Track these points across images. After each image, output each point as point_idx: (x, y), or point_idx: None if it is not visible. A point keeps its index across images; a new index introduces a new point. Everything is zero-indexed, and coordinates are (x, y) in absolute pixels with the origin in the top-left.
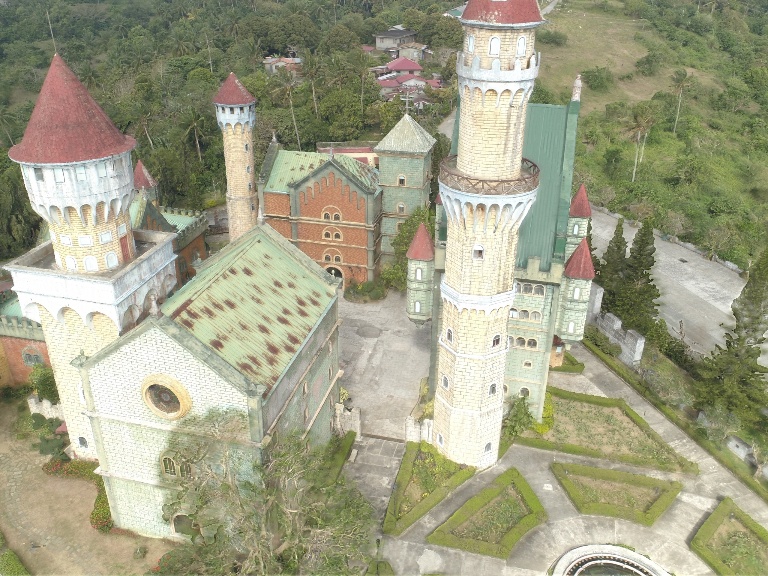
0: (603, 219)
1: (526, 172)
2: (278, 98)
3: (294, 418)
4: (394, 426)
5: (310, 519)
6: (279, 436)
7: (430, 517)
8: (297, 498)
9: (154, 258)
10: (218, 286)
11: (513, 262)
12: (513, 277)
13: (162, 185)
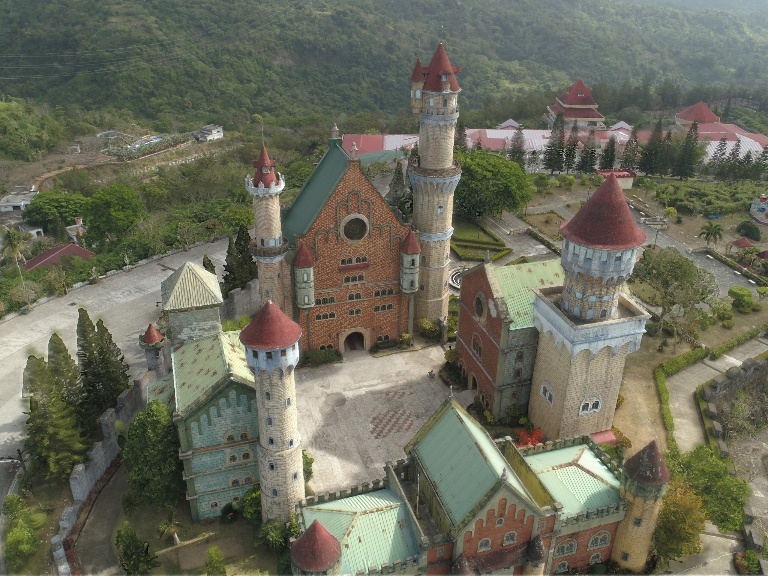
0: None
1: (415, 164)
2: None
3: None
4: (433, 353)
5: None
6: None
7: None
8: None
9: None
10: None
11: None
12: None
13: None
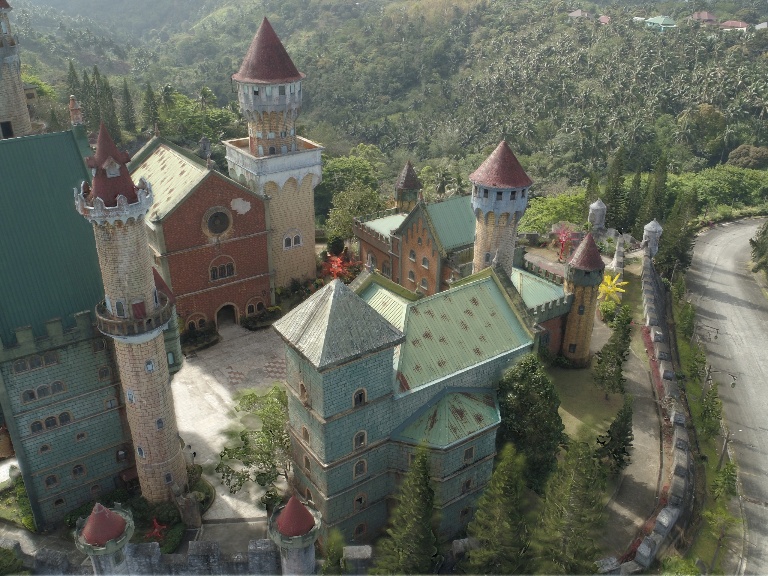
0: None
1: None
2: None
3: None
4: None
5: None
6: None
7: None
8: None
9: None
10: None
11: None
12: None
13: None
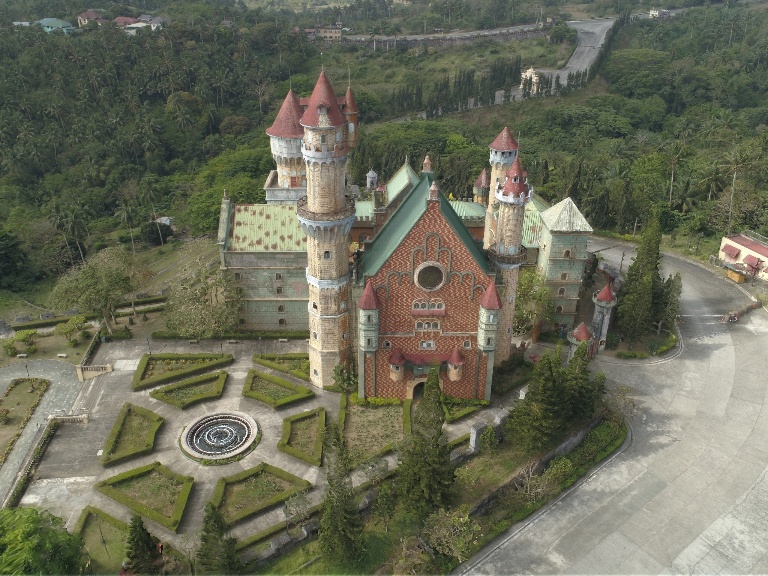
0: None
1: None
2: (723, 173)
3: (264, 282)
4: None
5: (256, 334)
6: (244, 279)
7: (271, 371)
8: (222, 300)
9: (302, 193)
10: (274, 208)
11: (319, 262)
12: (325, 274)
13: (595, 206)
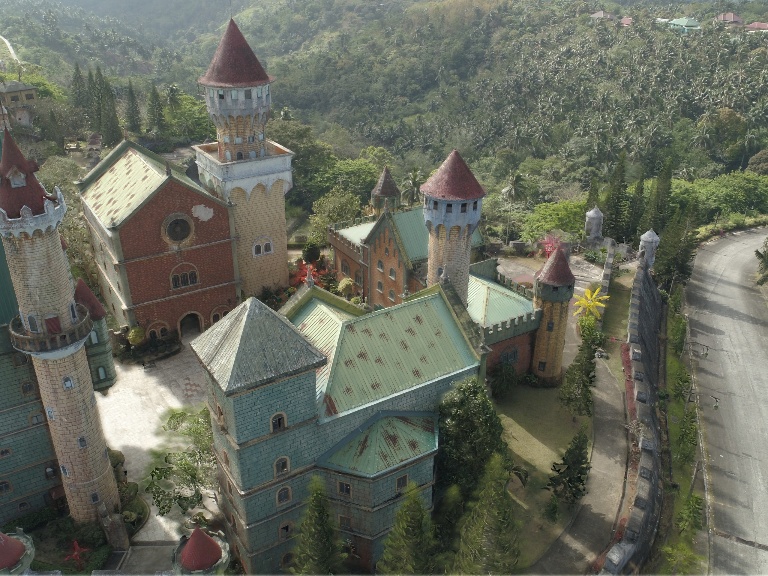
0: None
1: None
2: None
3: None
4: None
5: None
6: None
7: None
8: None
9: None
10: None
11: None
12: None
13: None
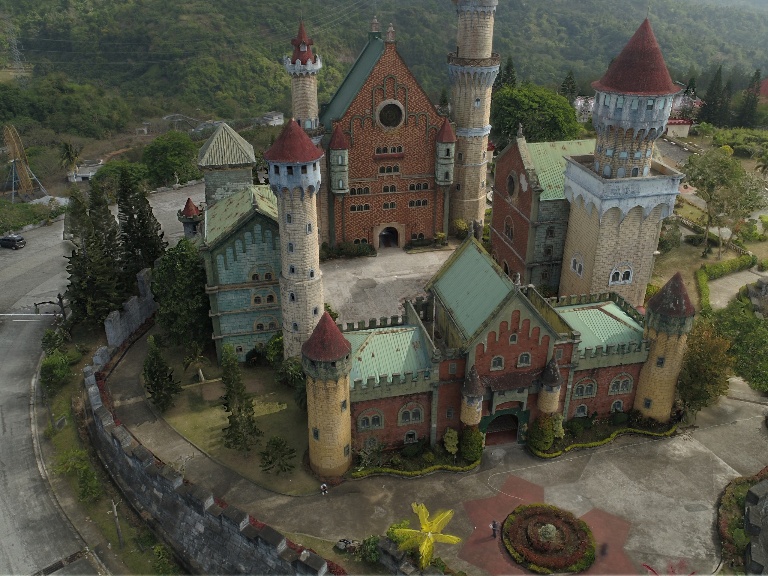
0: (33, 235)
1: None
2: None
3: None
4: None
5: None
6: None
7: None
8: None
9: None
10: None
11: None
12: None
13: None
